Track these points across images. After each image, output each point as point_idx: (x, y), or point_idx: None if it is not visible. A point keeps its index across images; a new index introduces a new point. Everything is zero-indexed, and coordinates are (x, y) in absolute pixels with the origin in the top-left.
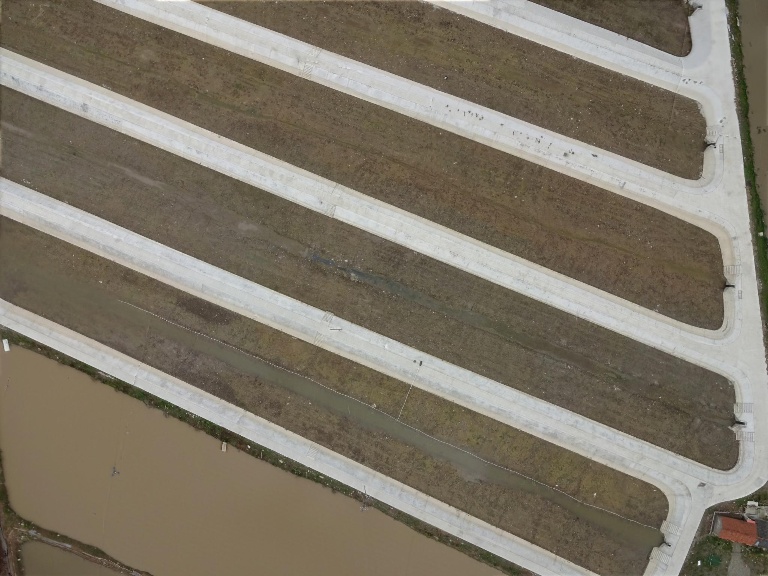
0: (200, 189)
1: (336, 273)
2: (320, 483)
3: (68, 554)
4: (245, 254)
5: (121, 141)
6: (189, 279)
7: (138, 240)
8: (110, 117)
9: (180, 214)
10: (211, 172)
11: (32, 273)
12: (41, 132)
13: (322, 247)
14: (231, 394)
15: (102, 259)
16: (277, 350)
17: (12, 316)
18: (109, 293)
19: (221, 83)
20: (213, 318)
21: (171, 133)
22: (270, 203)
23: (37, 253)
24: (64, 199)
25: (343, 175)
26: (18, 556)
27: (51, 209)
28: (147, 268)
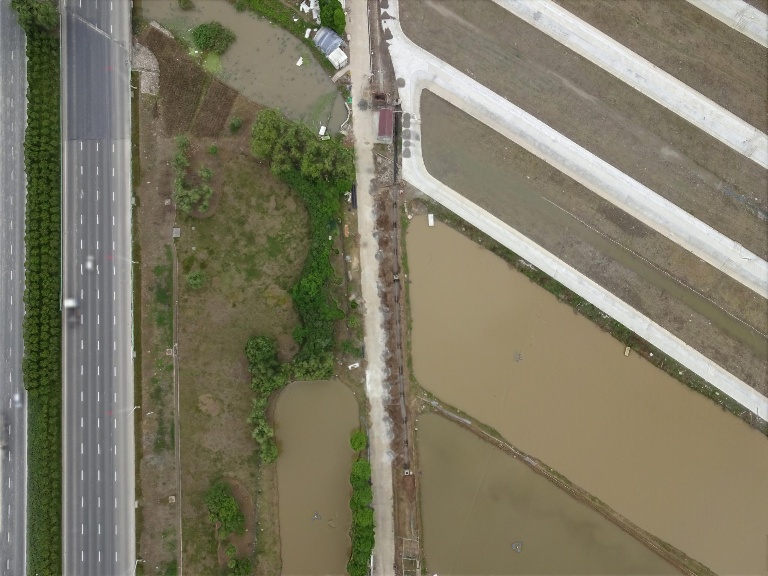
0: (630, 110)
1: (745, 209)
2: (712, 400)
3: (464, 431)
4: (666, 176)
5: (563, 53)
6: (616, 189)
7: (572, 145)
8: (560, 29)
9: (610, 129)
10: (642, 97)
11: (463, 157)
12: (489, 30)
13: (736, 183)
14: (639, 303)
15: (533, 156)
16: (685, 269)
17: (444, 193)
18: (535, 189)
19: (661, 19)
20: (630, 229)
21: (616, 54)
22: (693, 134)
23: (471, 140)
24: (504, 95)
25: (761, 122)
26: (416, 425)
27: (495, 101)
28: (577, 172)
